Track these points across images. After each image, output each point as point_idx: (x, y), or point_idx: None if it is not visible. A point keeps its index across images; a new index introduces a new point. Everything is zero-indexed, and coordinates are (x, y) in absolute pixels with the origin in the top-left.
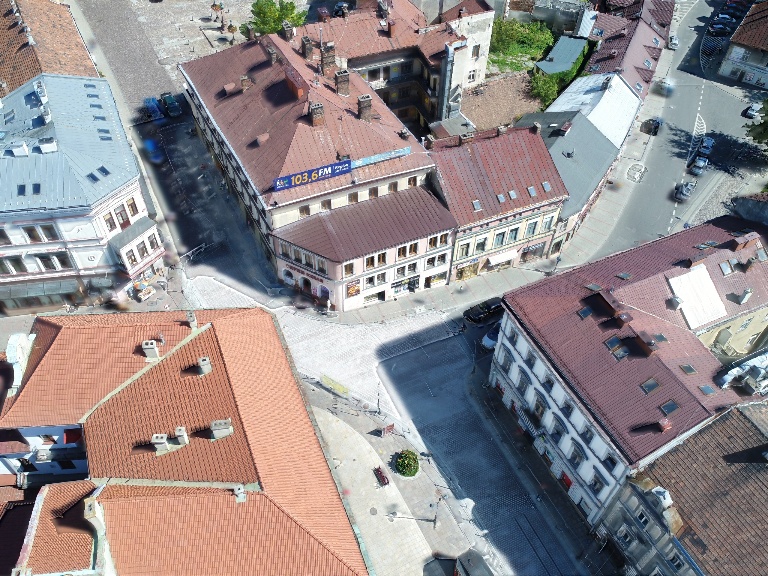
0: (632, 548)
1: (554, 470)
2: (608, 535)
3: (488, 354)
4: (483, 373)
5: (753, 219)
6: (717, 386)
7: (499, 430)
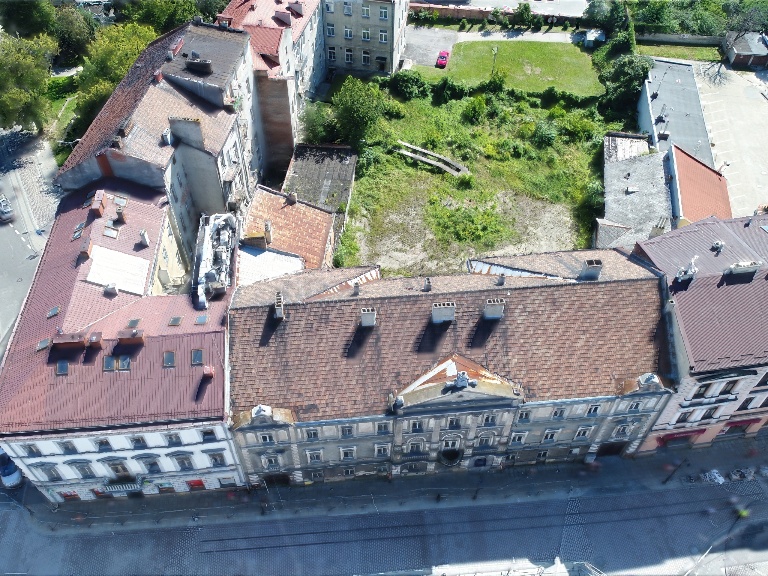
0: (282, 463)
1: (180, 489)
2: (260, 476)
3: (24, 487)
4: (40, 504)
5: (84, 184)
6: (203, 311)
7: (109, 521)
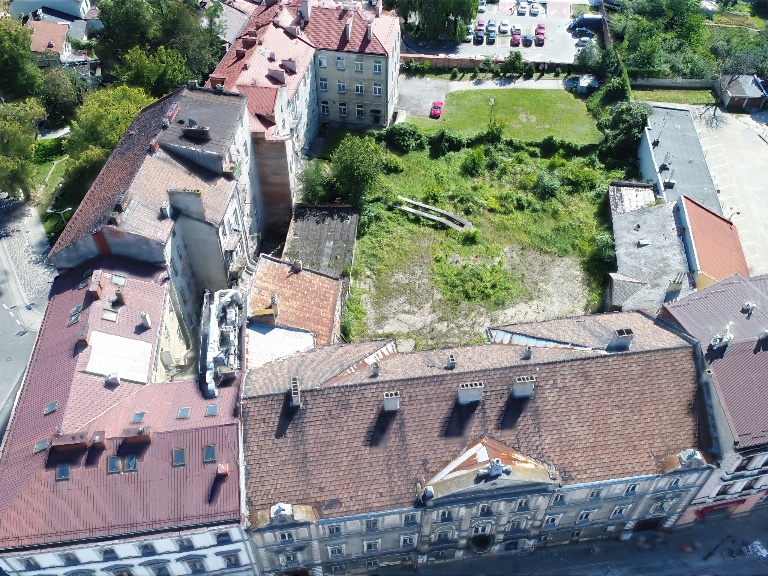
0: (301, 559)
1: None
2: (277, 573)
3: None
4: None
5: (79, 262)
6: (212, 399)
7: None
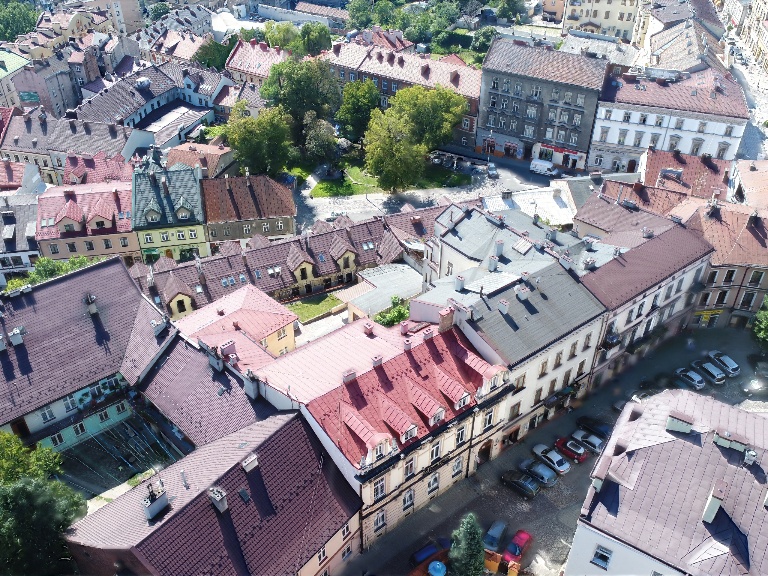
0: None
1: None
2: None
3: None
4: None
5: None
6: None
7: None
